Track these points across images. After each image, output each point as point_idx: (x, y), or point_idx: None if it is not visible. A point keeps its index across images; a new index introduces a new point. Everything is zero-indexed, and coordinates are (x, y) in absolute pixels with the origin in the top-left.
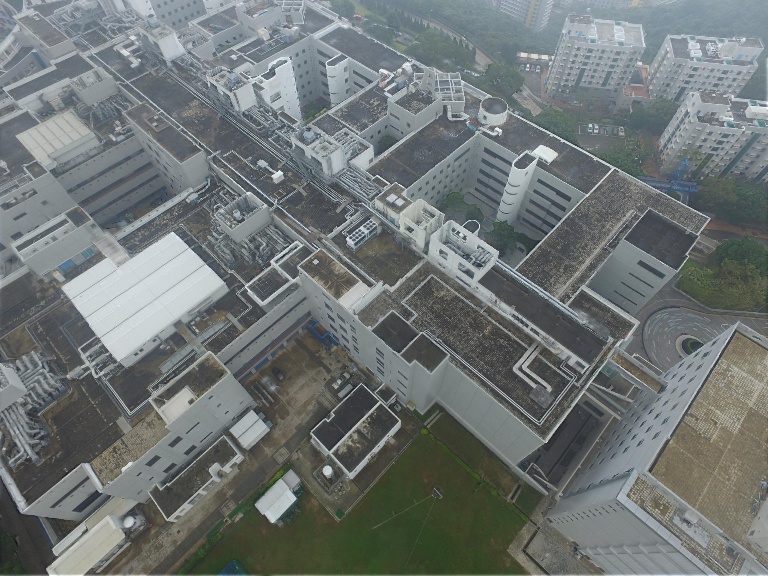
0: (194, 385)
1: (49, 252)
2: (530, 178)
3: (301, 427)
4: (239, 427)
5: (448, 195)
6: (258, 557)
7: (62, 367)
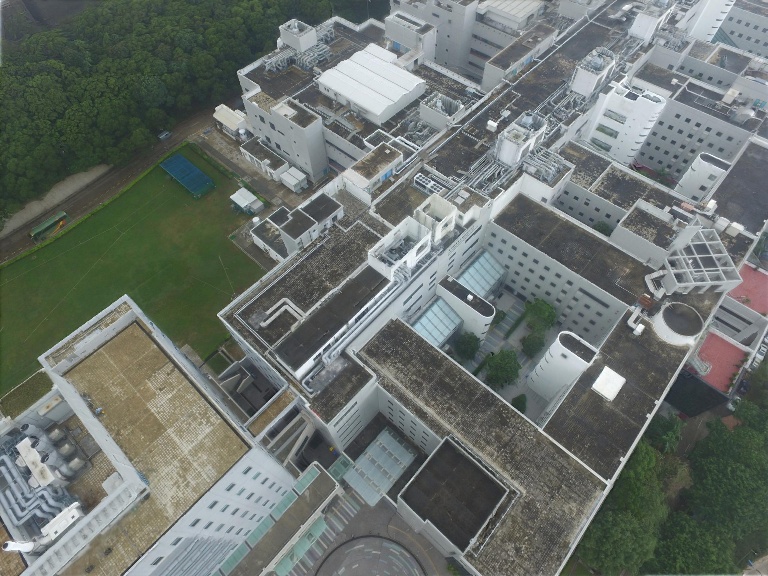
0: (298, 116)
1: (396, 28)
2: (575, 377)
3: None
4: (294, 171)
5: (546, 303)
6: (215, 197)
7: (323, 65)
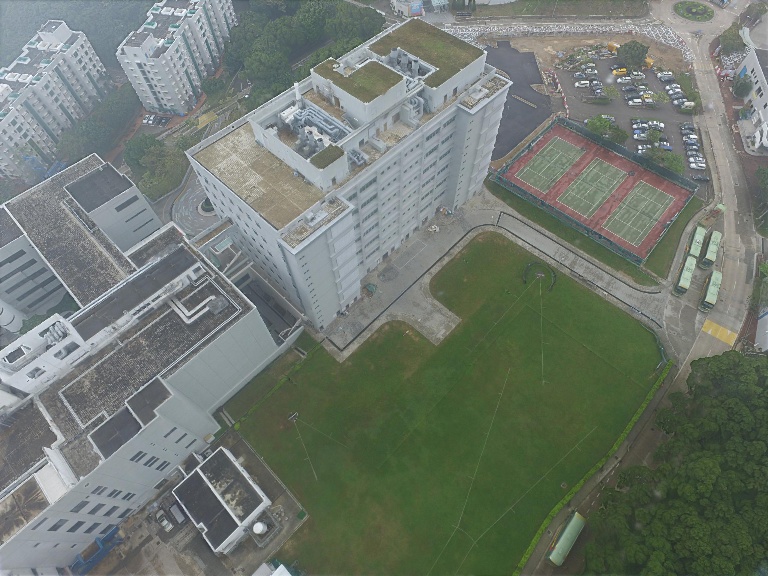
0: None
1: None
2: None
3: (208, 570)
4: None
5: None
6: None
7: None
